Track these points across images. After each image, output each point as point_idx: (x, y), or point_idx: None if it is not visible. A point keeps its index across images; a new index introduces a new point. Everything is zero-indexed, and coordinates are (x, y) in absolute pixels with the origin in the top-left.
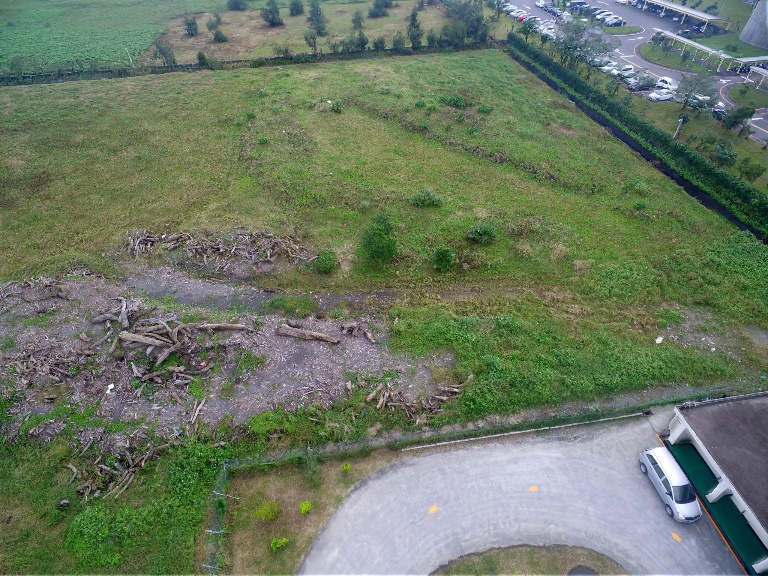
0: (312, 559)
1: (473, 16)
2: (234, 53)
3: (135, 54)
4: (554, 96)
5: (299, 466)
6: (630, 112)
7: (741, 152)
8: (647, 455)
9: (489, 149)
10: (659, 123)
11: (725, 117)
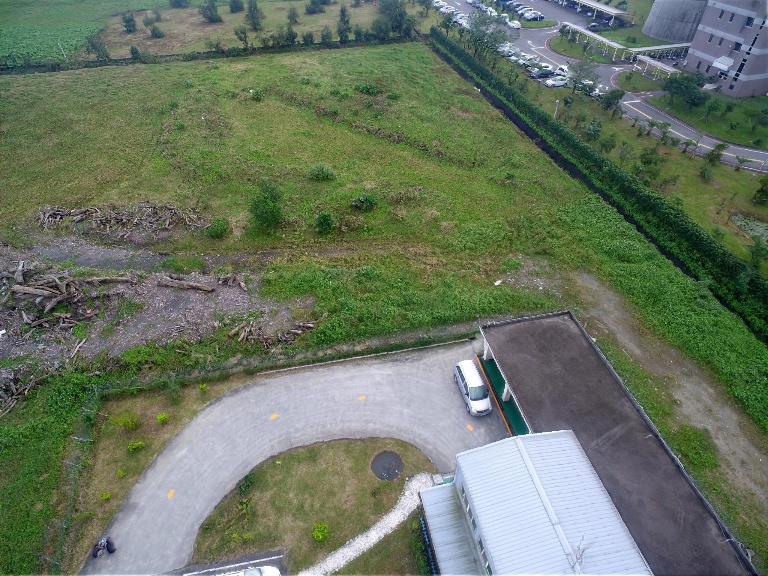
0: (163, 457)
1: (397, 11)
2: (169, 48)
3: (71, 49)
4: (461, 84)
5: (164, 389)
6: (521, 96)
7: (613, 129)
8: (456, 367)
9: (389, 130)
10: (548, 106)
11: (602, 99)
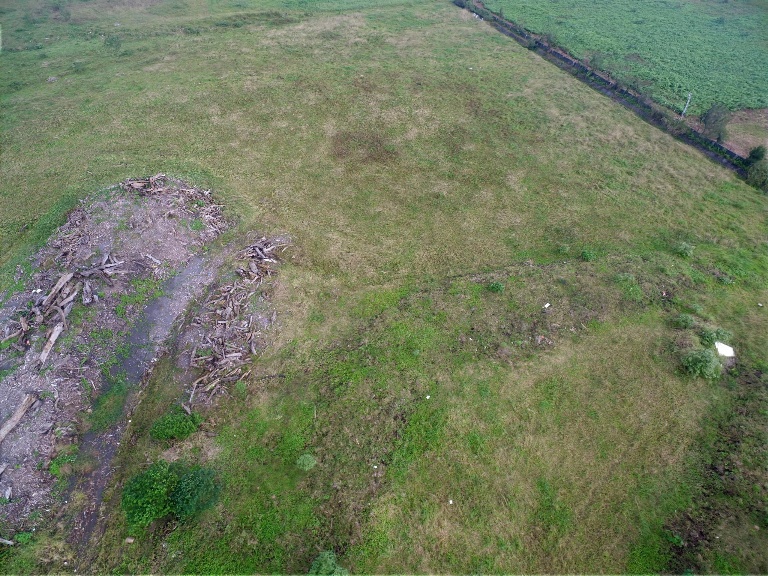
0: None
1: None
2: None
3: None
4: None
5: None
6: None
7: None
8: None
9: None
10: None
11: None
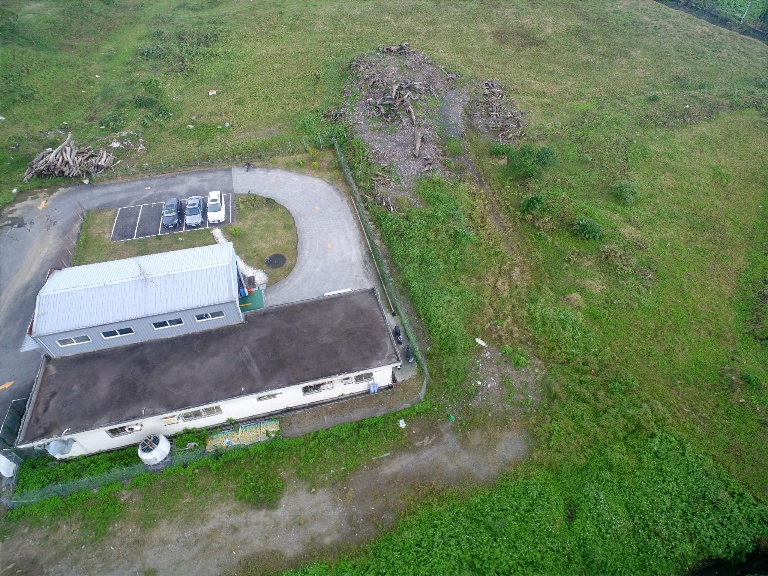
0: (294, 174)
1: None
2: None
3: None
4: None
5: None
6: None
7: None
8: None
9: None
10: None
11: None
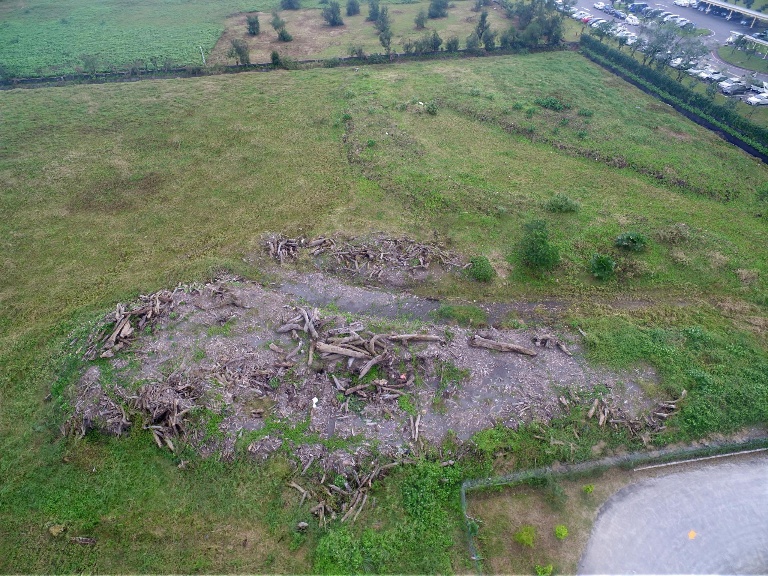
0: None
1: None
2: (303, 53)
3: (203, 53)
4: (649, 99)
5: (535, 487)
6: (740, 116)
7: None
8: None
9: (605, 153)
10: None
11: None
